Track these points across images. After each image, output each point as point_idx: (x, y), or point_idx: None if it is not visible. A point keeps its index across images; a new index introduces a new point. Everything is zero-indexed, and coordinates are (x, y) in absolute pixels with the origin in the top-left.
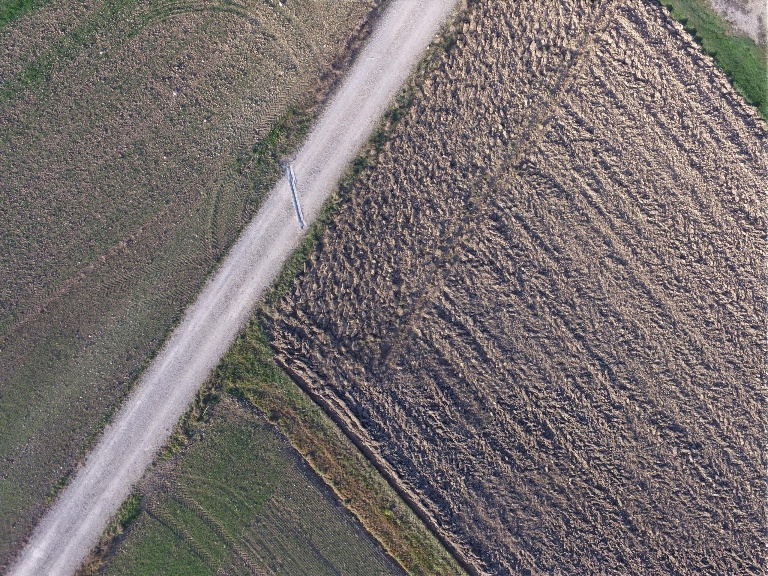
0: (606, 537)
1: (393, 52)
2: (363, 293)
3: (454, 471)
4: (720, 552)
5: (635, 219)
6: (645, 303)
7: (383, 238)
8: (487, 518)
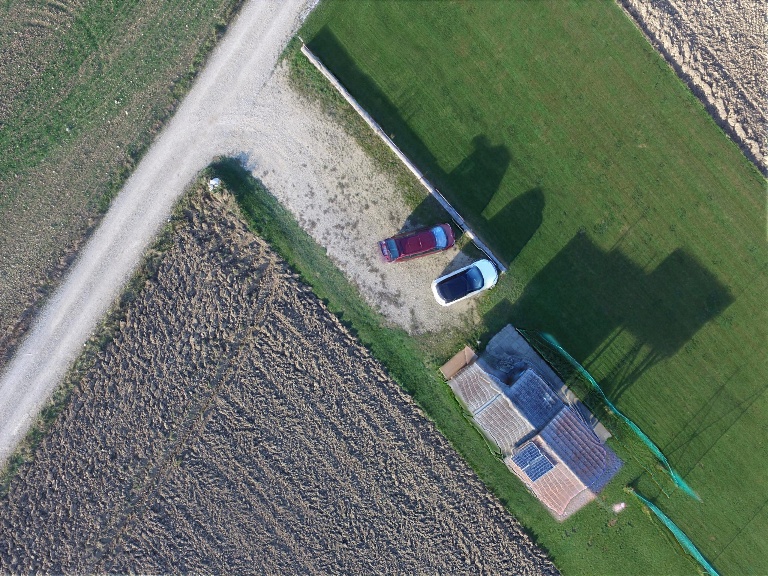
0: None
1: (50, 348)
2: None
3: None
4: None
5: (298, 505)
6: None
7: (42, 533)
8: None
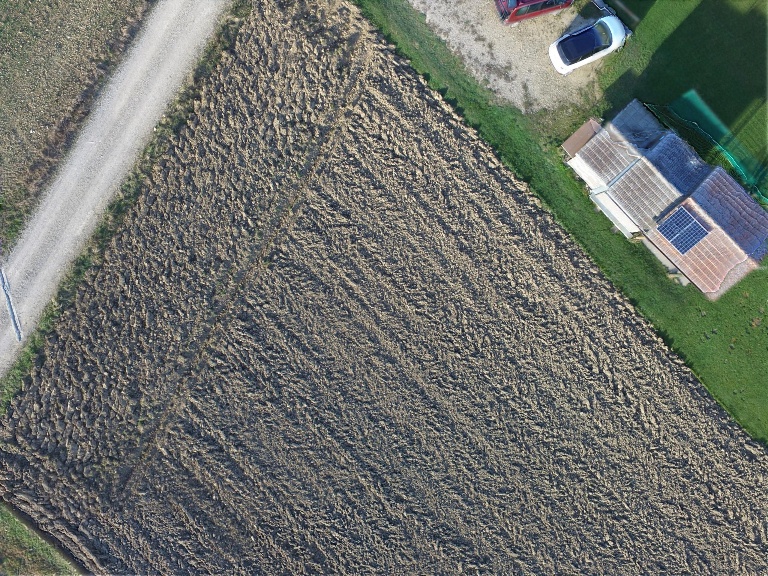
0: None
1: (115, 135)
2: (95, 410)
3: None
4: None
5: (403, 311)
6: (418, 404)
7: (115, 346)
8: None
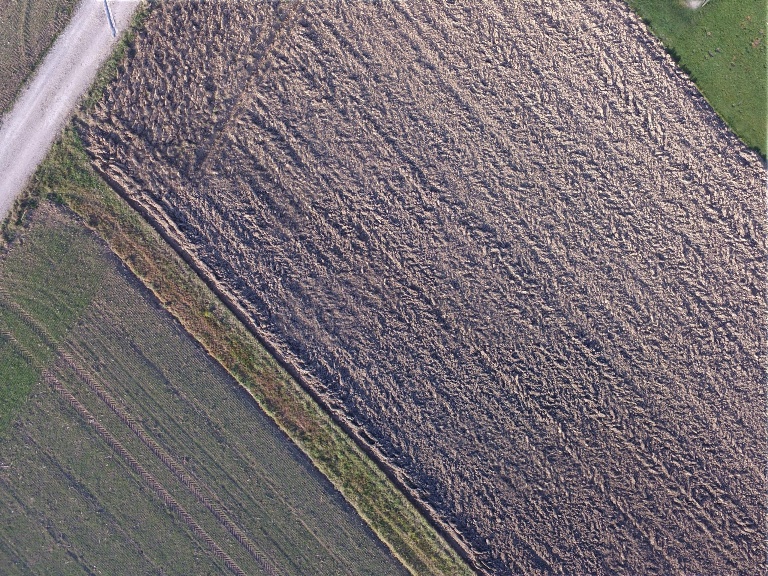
0: (420, 335)
1: None
2: (177, 99)
3: (271, 273)
4: (529, 347)
5: (441, 24)
6: (453, 106)
7: (195, 44)
8: (304, 318)
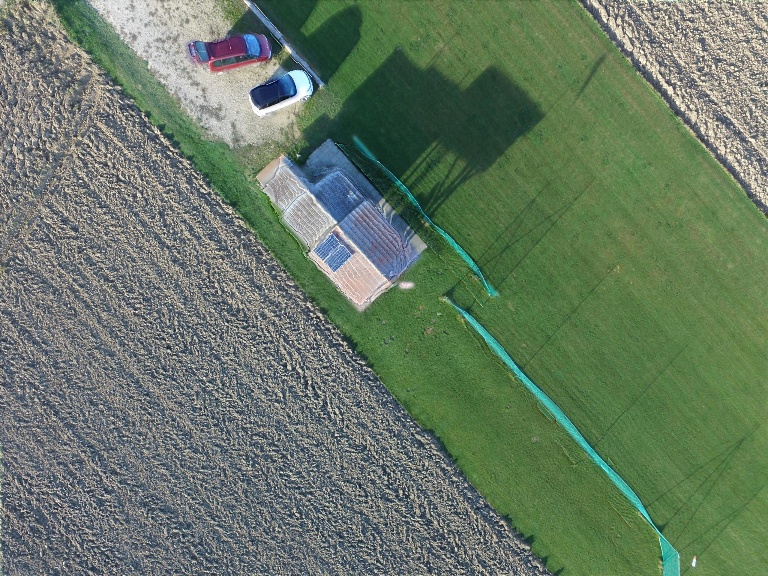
0: None
1: None
2: None
3: None
4: None
5: (122, 312)
6: (134, 392)
7: None
8: None
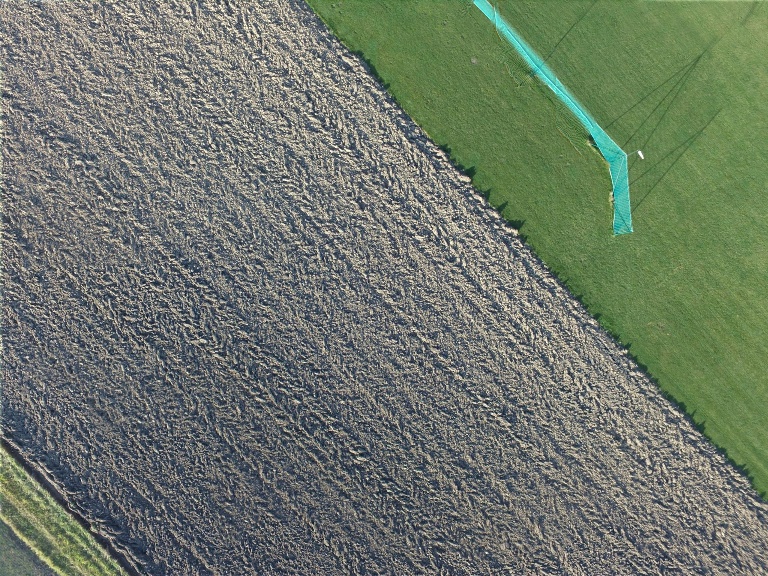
0: None
1: None
2: None
3: None
4: (122, 268)
5: None
6: (22, 3)
7: None
8: None
